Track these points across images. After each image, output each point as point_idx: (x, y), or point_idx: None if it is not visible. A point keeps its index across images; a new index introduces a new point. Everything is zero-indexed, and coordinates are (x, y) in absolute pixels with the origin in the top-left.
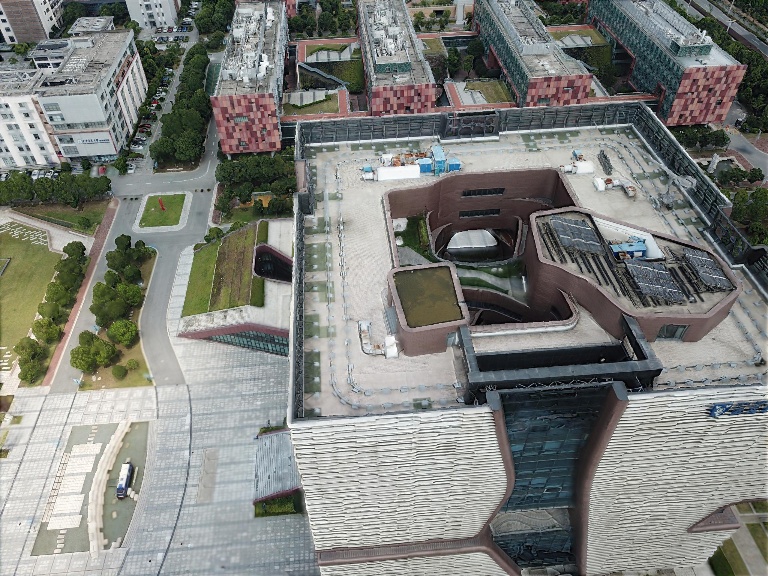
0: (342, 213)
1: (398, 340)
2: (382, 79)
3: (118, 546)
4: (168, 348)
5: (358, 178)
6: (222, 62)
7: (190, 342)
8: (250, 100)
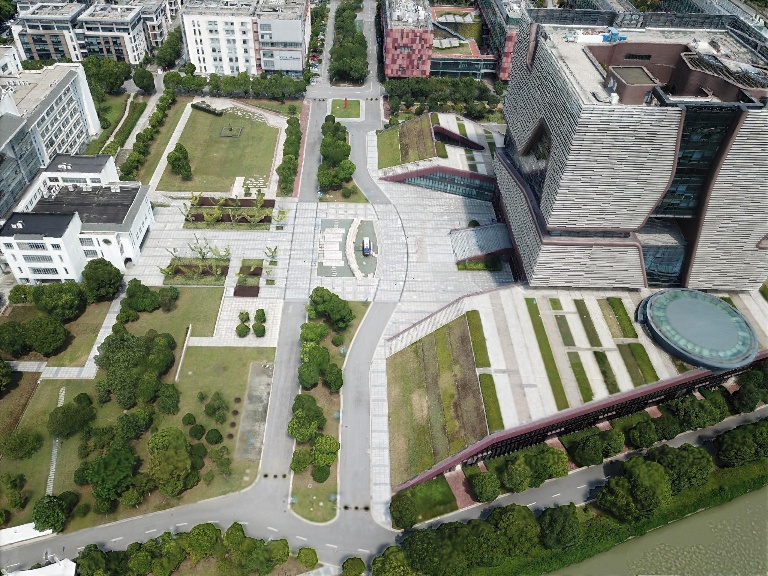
0: (561, 54)
1: (619, 94)
2: (513, 29)
3: (372, 276)
4: (374, 185)
5: (564, 41)
6: (387, 9)
7: (389, 183)
8: (416, 34)
